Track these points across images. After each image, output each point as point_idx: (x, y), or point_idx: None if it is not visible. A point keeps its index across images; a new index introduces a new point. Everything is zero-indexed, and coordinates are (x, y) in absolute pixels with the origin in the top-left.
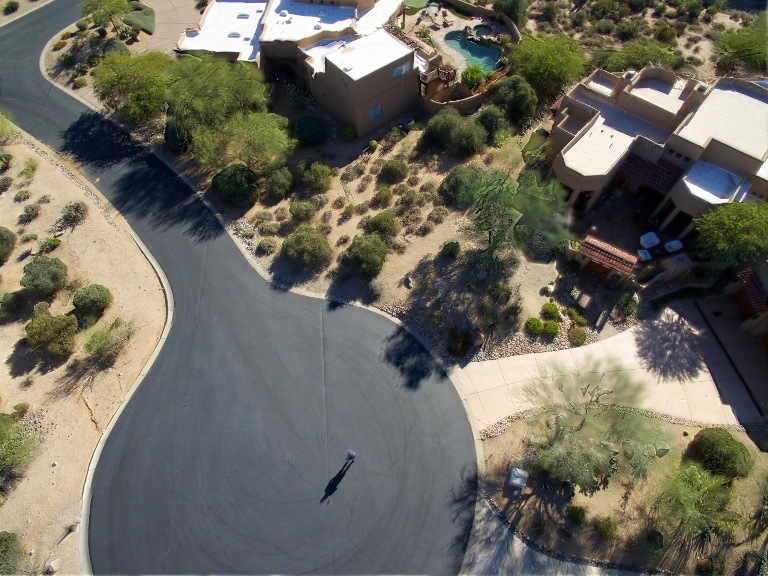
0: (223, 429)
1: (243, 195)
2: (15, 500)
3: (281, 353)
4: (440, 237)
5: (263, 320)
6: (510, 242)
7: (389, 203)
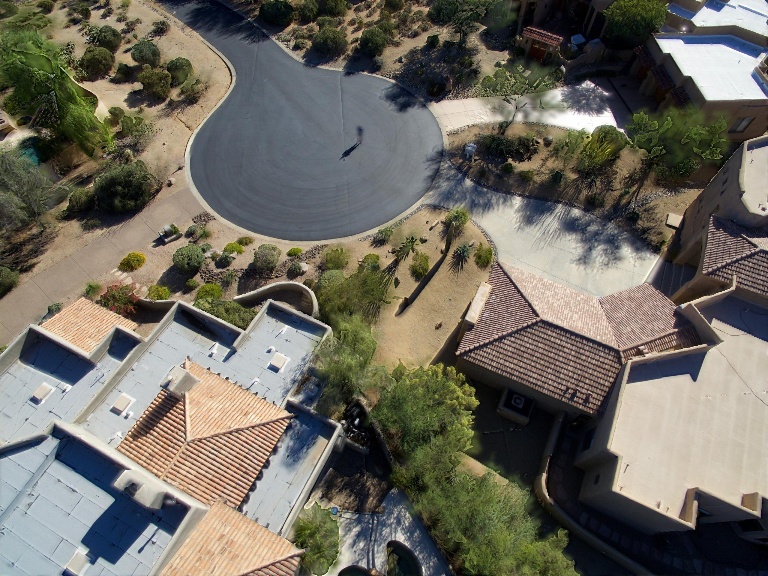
0: (274, 128)
1: (283, 15)
2: (141, 159)
3: (312, 95)
4: (426, 38)
5: (299, 80)
6: (476, 39)
7: (389, 22)
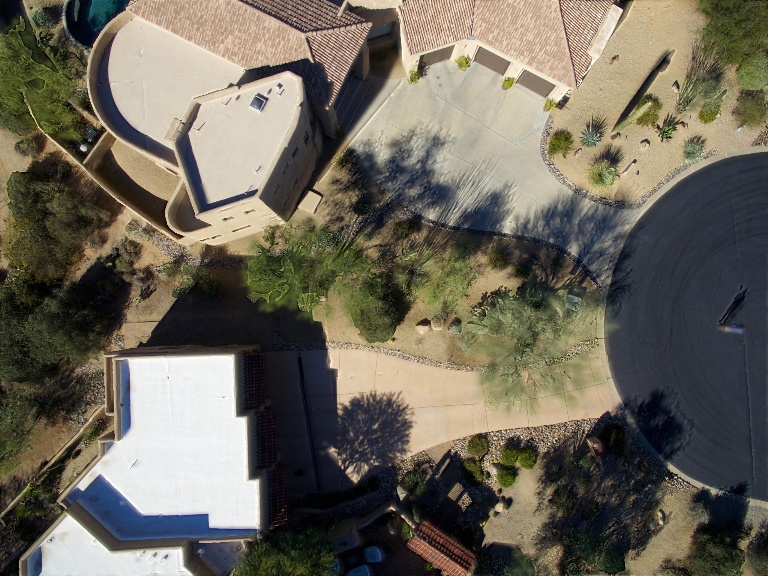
0: None
1: None
2: None
3: None
4: None
5: None
6: (537, 575)
7: None
